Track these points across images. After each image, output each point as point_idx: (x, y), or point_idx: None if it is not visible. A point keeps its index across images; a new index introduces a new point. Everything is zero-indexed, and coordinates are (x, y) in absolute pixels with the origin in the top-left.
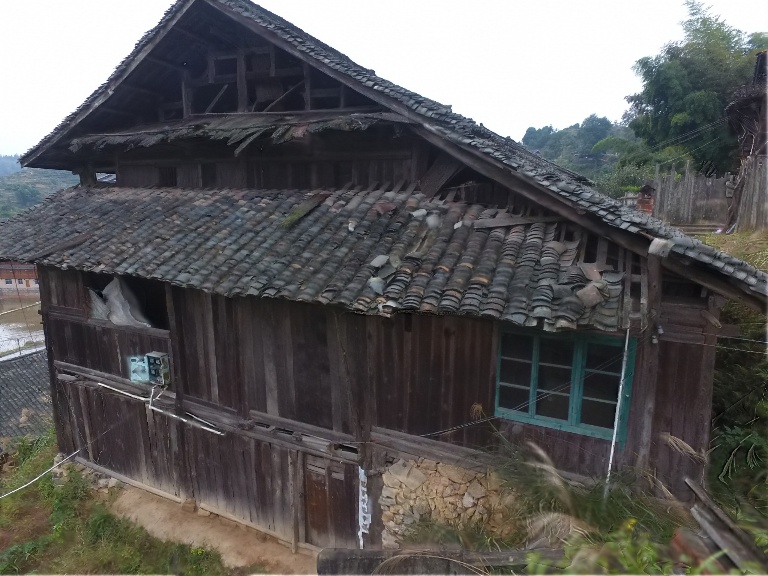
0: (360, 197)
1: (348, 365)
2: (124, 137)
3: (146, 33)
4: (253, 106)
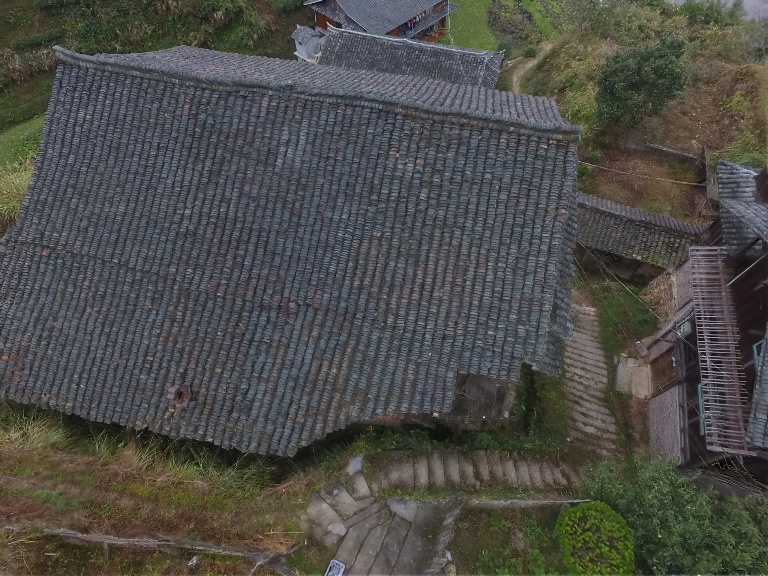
0: None
1: None
2: None
3: None
4: None
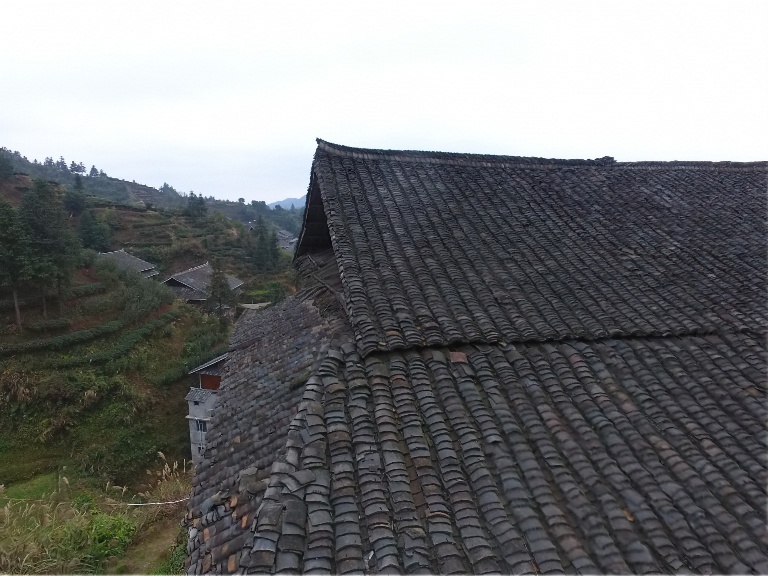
0: None
1: None
2: None
3: None
4: None
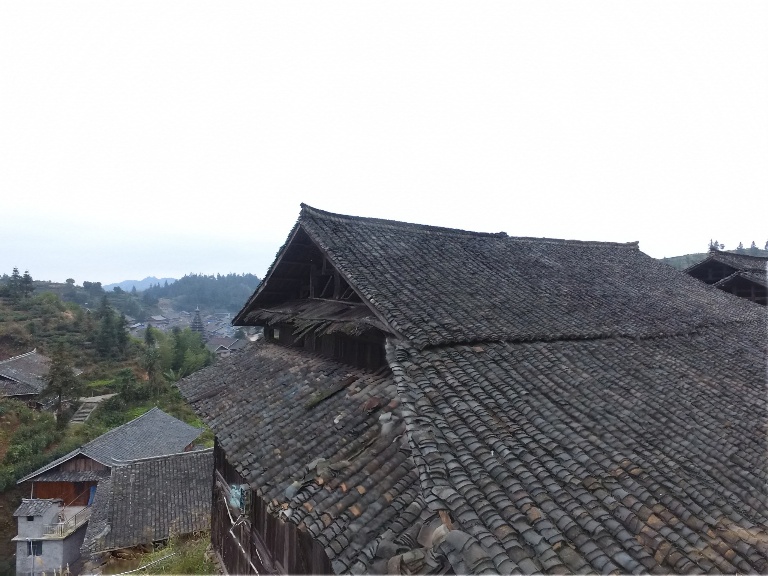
0: (371, 386)
1: (302, 551)
2: (269, 314)
3: (280, 248)
4: (345, 292)
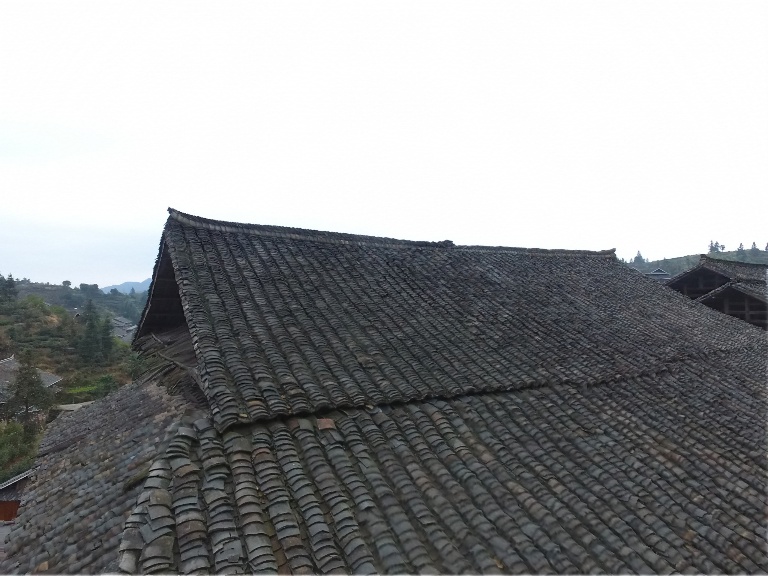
0: None
1: None
2: None
3: None
4: None
